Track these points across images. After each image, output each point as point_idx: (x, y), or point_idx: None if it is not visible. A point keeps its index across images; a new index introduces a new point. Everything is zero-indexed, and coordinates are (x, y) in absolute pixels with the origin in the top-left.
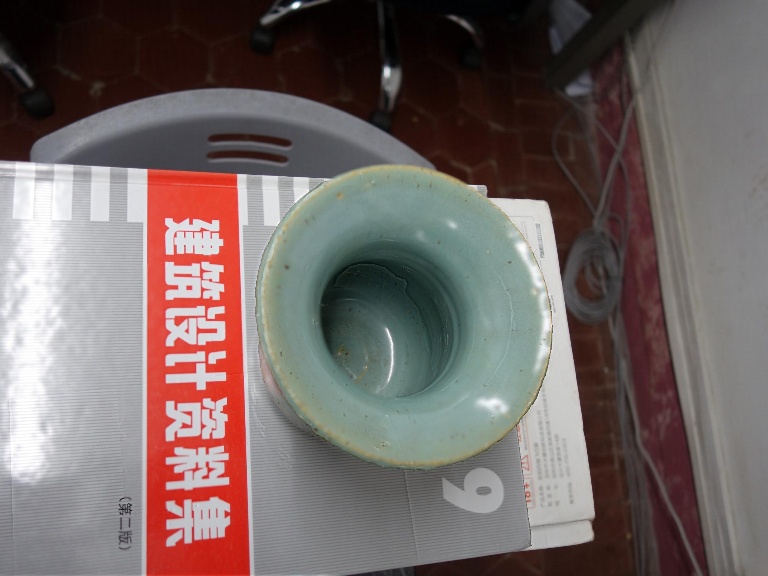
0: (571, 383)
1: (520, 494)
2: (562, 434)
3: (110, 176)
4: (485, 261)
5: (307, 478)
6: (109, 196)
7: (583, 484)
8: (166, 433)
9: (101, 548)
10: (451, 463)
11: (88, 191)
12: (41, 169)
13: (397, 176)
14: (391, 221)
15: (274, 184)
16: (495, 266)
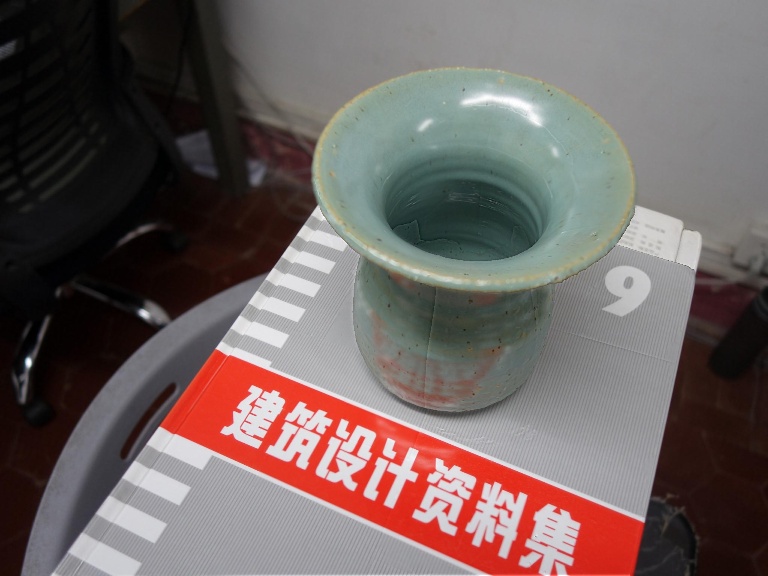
0: None
1: (643, 257)
2: None
3: (144, 466)
4: (451, 110)
5: (552, 422)
6: (164, 475)
7: (650, 216)
8: (446, 532)
9: None
10: None
11: (146, 493)
12: (93, 530)
13: (339, 127)
14: (374, 160)
15: (245, 323)
16: (460, 104)
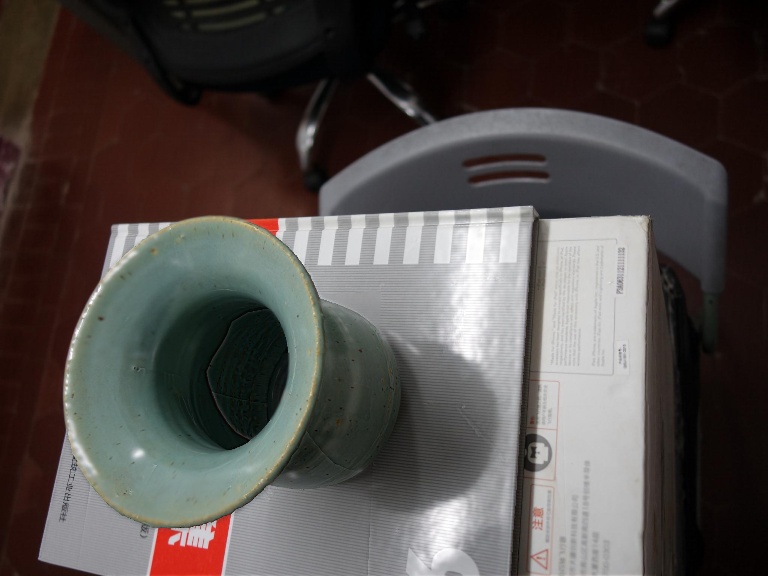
0: (633, 467)
1: None
2: (605, 534)
3: None
4: (286, 313)
5: (280, 513)
6: None
7: None
8: None
9: (130, 531)
10: (172, 526)
11: None
12: (152, 228)
13: (203, 228)
14: (213, 272)
15: (308, 225)
16: (291, 320)
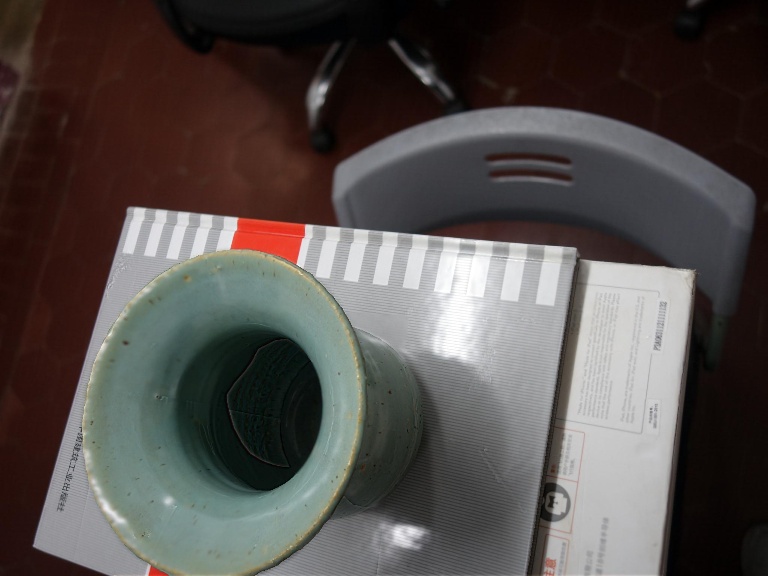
0: (652, 531)
1: None
2: None
3: (212, 223)
4: (325, 366)
5: None
6: (206, 241)
7: None
8: None
9: None
10: None
11: (194, 236)
12: (170, 216)
13: (242, 262)
14: (248, 307)
15: (336, 235)
16: (330, 374)
